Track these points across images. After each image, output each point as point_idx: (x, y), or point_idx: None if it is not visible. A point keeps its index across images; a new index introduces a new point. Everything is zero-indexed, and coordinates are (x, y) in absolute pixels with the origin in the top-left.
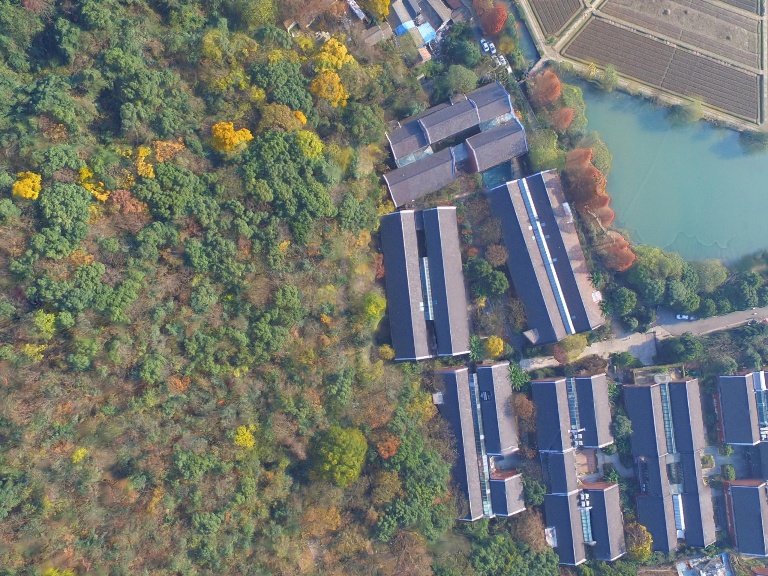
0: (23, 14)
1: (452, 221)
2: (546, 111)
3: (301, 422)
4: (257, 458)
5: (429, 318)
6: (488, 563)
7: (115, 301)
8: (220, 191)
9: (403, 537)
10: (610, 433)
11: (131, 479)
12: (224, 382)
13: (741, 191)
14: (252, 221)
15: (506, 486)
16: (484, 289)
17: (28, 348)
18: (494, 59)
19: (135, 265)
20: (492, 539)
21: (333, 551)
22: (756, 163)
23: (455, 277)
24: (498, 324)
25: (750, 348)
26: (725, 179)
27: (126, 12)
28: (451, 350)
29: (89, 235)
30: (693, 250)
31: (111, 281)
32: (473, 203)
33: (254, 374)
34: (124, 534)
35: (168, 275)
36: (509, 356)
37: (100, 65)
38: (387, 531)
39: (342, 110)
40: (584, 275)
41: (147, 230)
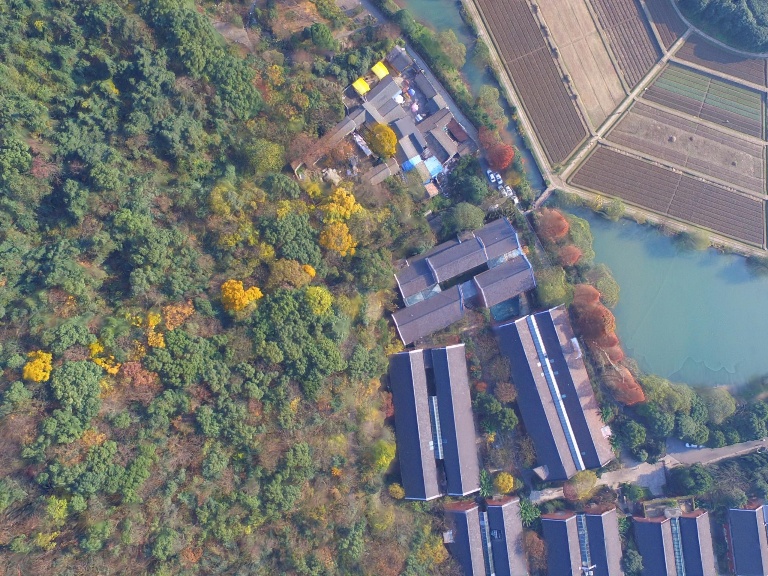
0: (32, 180)
1: (461, 359)
2: (553, 241)
3: None
4: None
5: (439, 457)
6: None
7: (127, 483)
8: (230, 355)
9: None
10: (621, 568)
11: None
12: (236, 543)
13: (748, 316)
14: (262, 383)
15: None
16: (493, 425)
17: (41, 538)
18: (501, 190)
19: (146, 435)
20: None
21: None
22: (763, 287)
23: (464, 415)
24: (508, 460)
25: (760, 479)
26: (732, 304)
27: (134, 166)
28: (461, 490)
29: (100, 412)
30: (701, 376)
31: (123, 461)
32: (482, 340)
33: (265, 528)
34: None
35: (179, 446)
36: (519, 491)
37: (109, 226)
38: None
39: (350, 258)
40: (593, 411)
41: (158, 400)
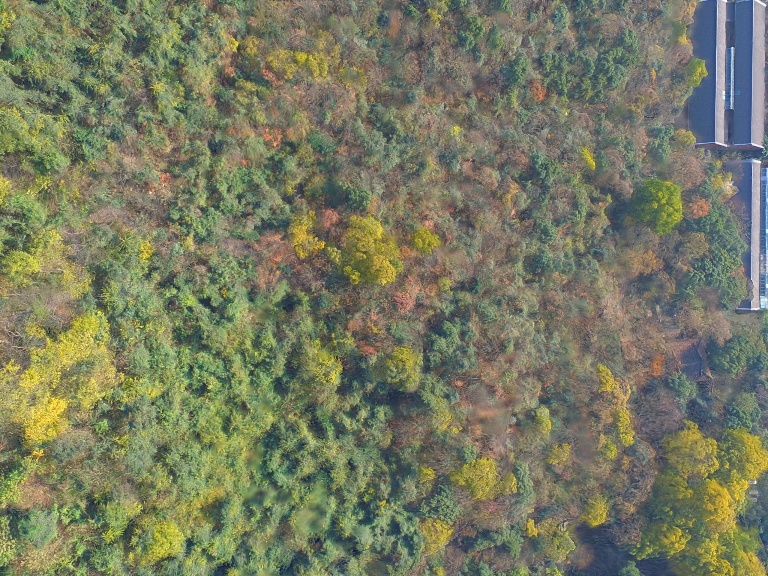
0: None
1: (762, 17)
2: None
3: None
4: None
5: (730, 107)
6: None
7: None
8: None
9: (686, 312)
10: None
11: None
12: None
13: None
14: None
15: None
16: None
17: (431, 11)
18: None
19: None
20: None
21: (625, 309)
22: None
23: (759, 71)
24: None
25: None
26: None
27: None
28: (750, 139)
29: None
30: None
31: None
32: None
33: None
34: (479, 220)
35: None
36: None
37: None
38: (694, 286)
39: None
40: None
41: None
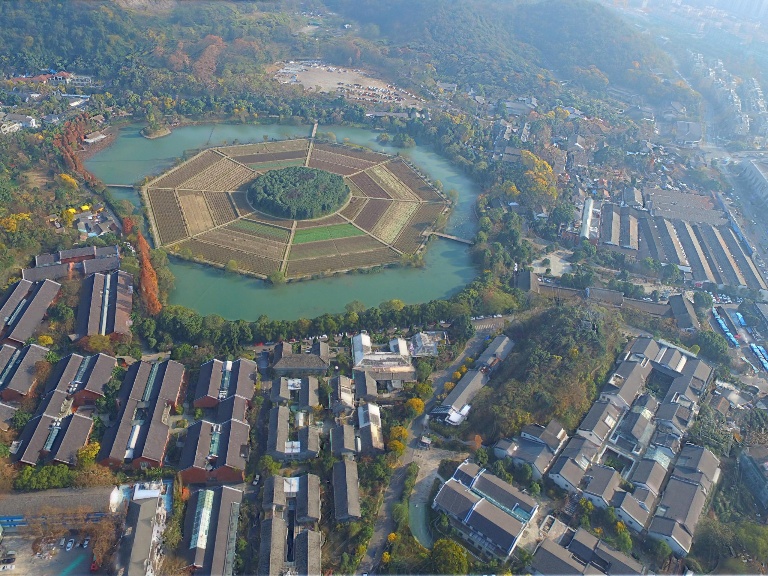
0: None
1: (54, 288)
2: None
3: None
4: None
5: (7, 324)
6: None
7: None
8: None
9: None
10: (102, 389)
11: None
12: None
13: (260, 303)
14: None
15: None
16: (57, 318)
17: None
18: None
19: None
20: None
21: None
22: (272, 292)
23: (39, 309)
24: None
25: None
26: (250, 297)
27: None
28: (9, 335)
29: None
30: None
31: None
32: None
33: None
34: None
35: None
36: (54, 351)
37: None
38: None
39: (12, 235)
40: (125, 313)
41: None
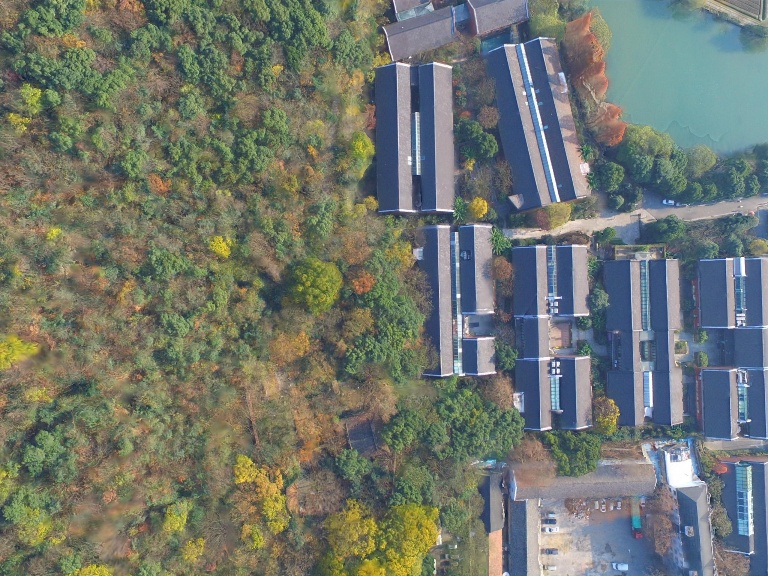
0: None
1: (447, 80)
2: None
3: (279, 248)
4: (231, 275)
5: (416, 173)
6: (453, 411)
7: (103, 86)
8: (218, 3)
9: (371, 383)
10: (586, 305)
11: (103, 269)
12: (205, 197)
13: (738, 86)
14: (247, 38)
15: (478, 345)
16: (473, 151)
17: (12, 116)
18: None
19: (126, 63)
20: (459, 392)
21: (300, 386)
22: (755, 59)
23: (445, 135)
24: (484, 187)
25: (733, 235)
26: (723, 72)
27: None
28: (435, 205)
29: (83, 23)
30: (685, 140)
31: (101, 67)
32: (469, 64)
33: None
34: (91, 321)
35: (158, 76)
36: (492, 221)
37: None
38: (355, 364)
39: None
40: (574, 145)
41: (141, 30)
